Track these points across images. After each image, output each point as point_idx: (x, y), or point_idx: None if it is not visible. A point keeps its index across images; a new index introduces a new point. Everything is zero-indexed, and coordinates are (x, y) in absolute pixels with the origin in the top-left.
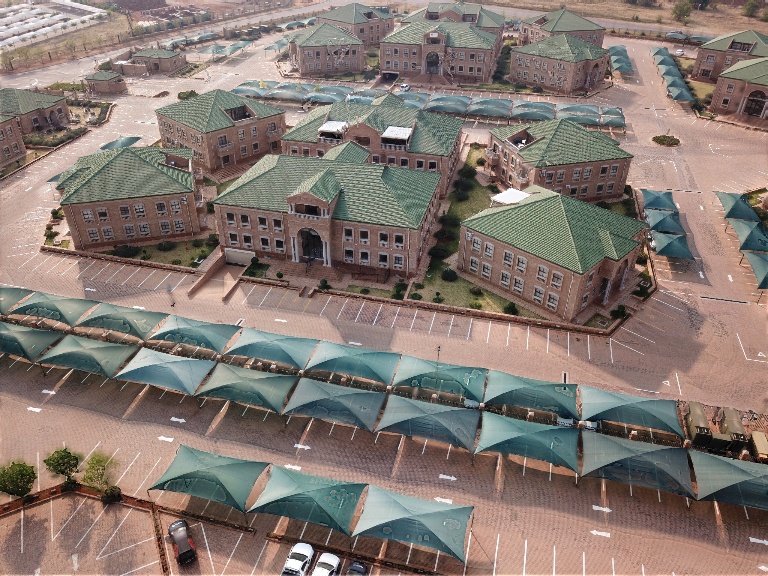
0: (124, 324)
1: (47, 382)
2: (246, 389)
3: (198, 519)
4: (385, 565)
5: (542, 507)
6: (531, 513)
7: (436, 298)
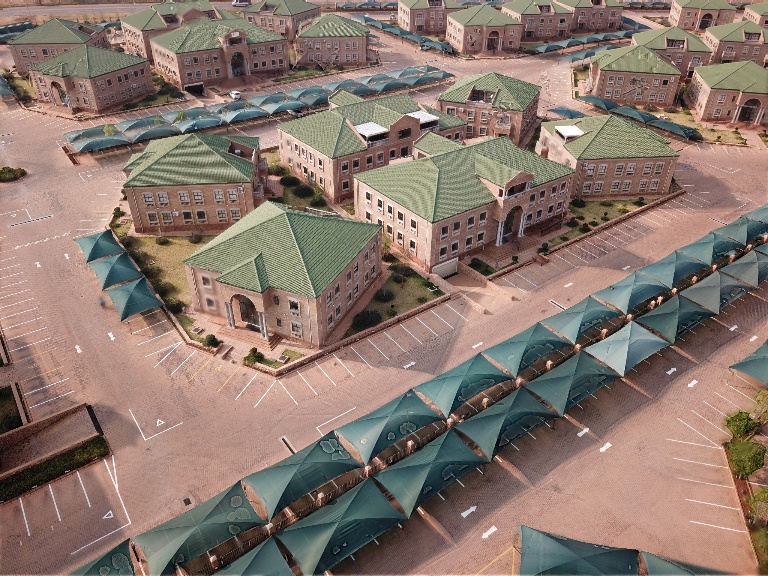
0: None
1: (566, 429)
2: (688, 315)
3: None
4: None
5: None
6: None
7: (604, 218)
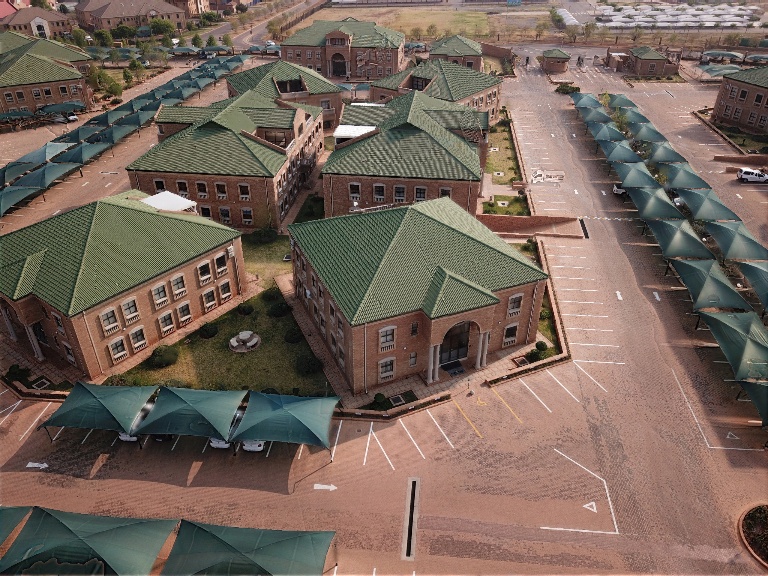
0: None
1: None
2: None
3: None
4: None
5: None
6: None
7: None
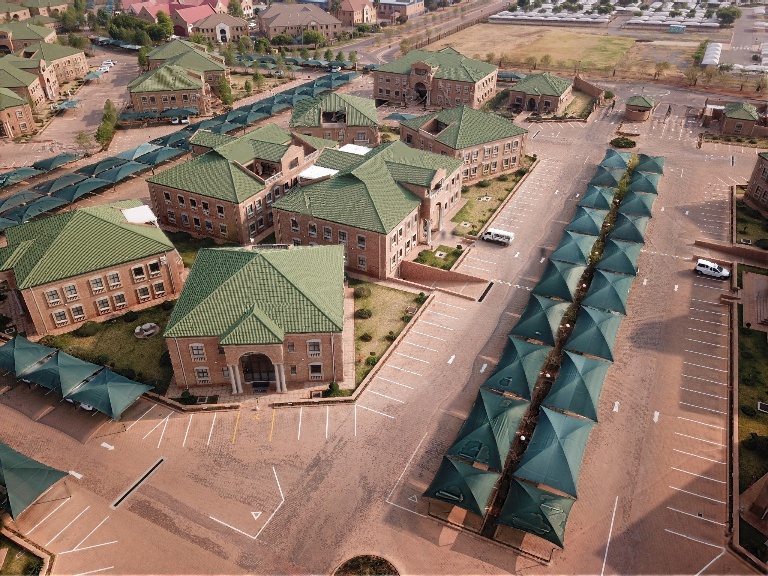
0: None
1: None
2: None
3: (53, 169)
4: None
5: None
6: None
7: None
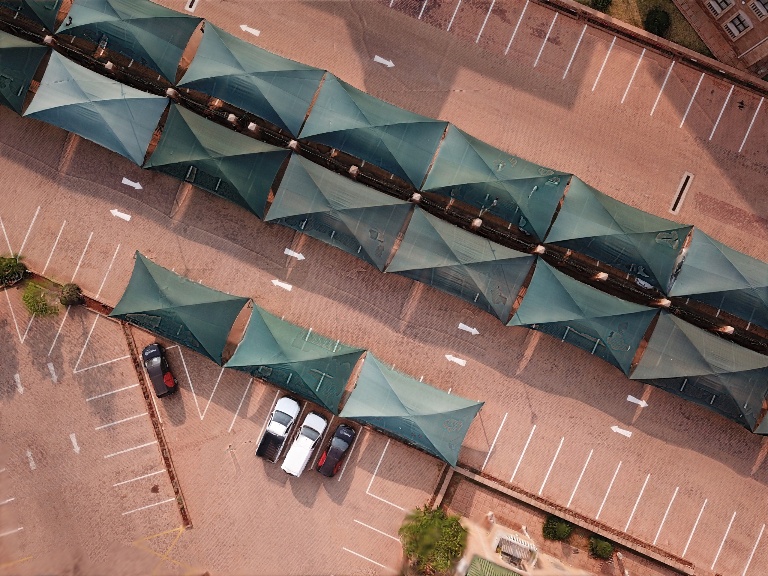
0: None
1: None
2: (213, 173)
3: (174, 342)
4: (375, 431)
5: (568, 388)
6: (553, 393)
7: None
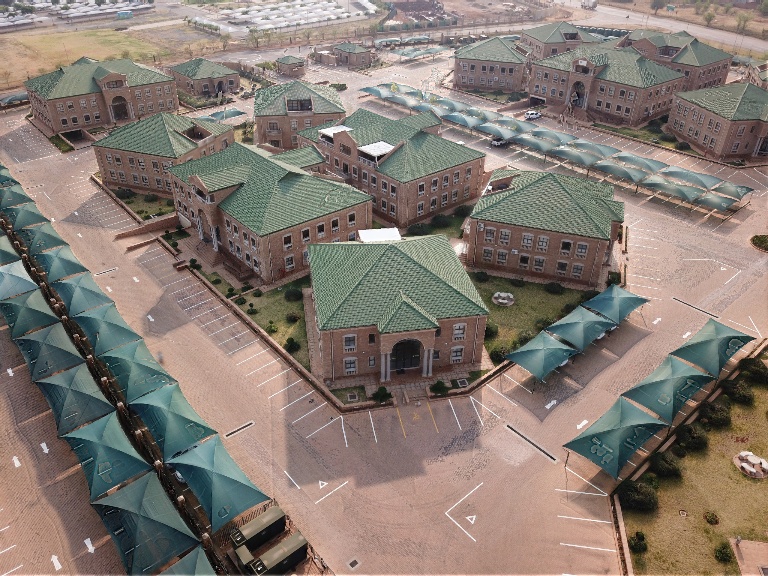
0: (32, 239)
1: None
2: (16, 312)
3: None
4: None
5: (58, 512)
6: (44, 511)
7: (251, 309)
